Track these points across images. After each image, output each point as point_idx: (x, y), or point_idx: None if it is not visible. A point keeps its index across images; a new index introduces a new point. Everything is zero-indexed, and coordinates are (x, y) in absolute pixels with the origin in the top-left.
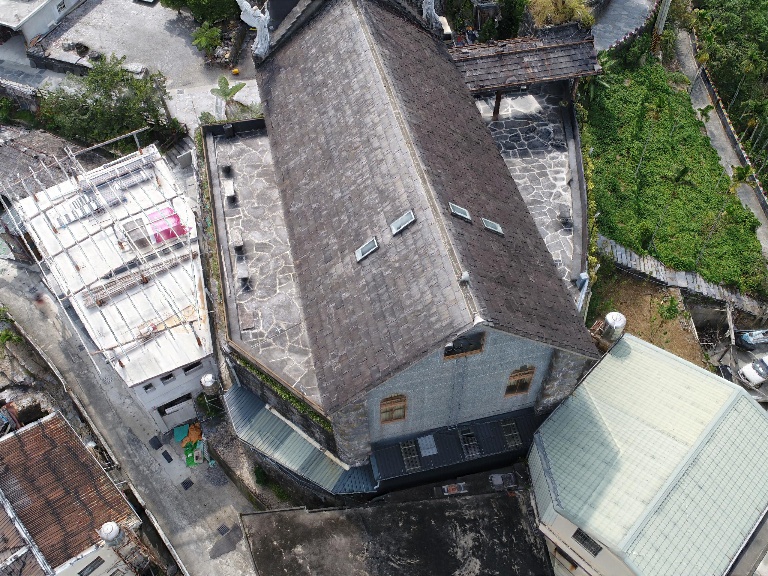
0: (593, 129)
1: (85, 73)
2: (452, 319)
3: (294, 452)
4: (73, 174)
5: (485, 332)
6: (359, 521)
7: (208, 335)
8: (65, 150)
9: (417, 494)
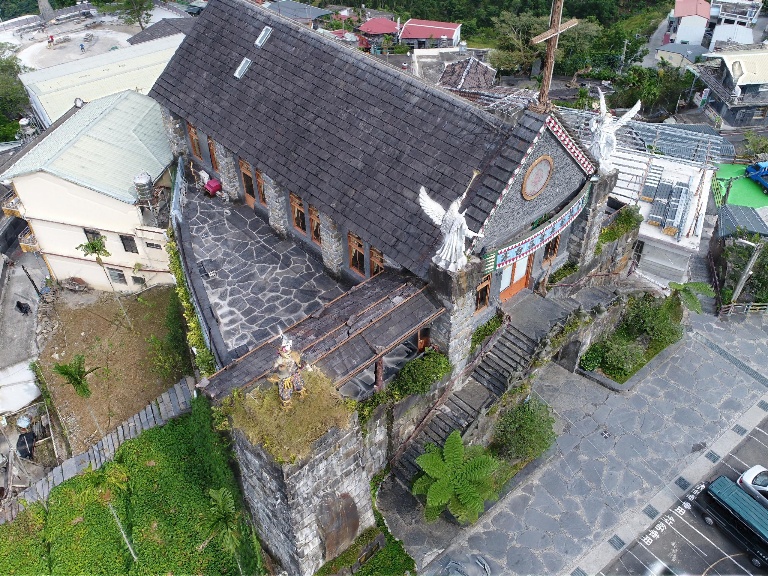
0: None
1: None
2: None
3: None
4: None
5: None
6: None
7: None
8: None
9: None
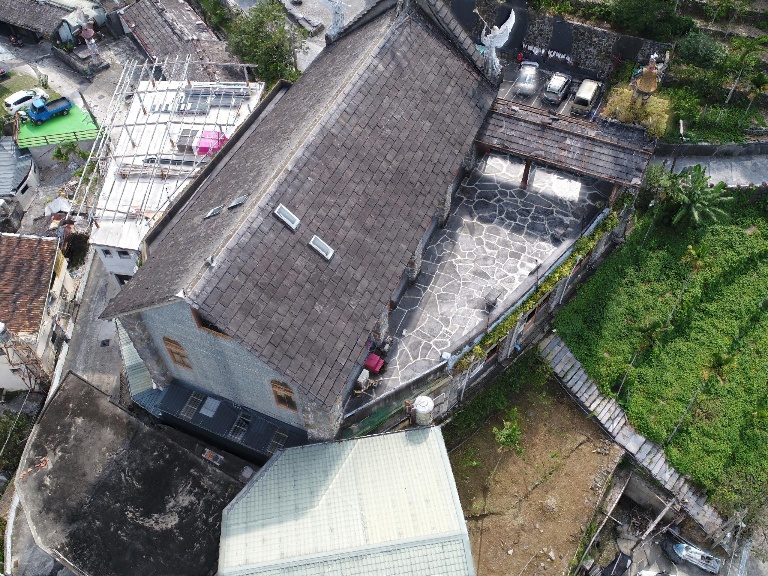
0: (665, 254)
1: (283, 11)
2: None
3: (136, 352)
4: (187, 77)
5: None
6: (133, 430)
7: None
8: (187, 56)
9: (185, 441)
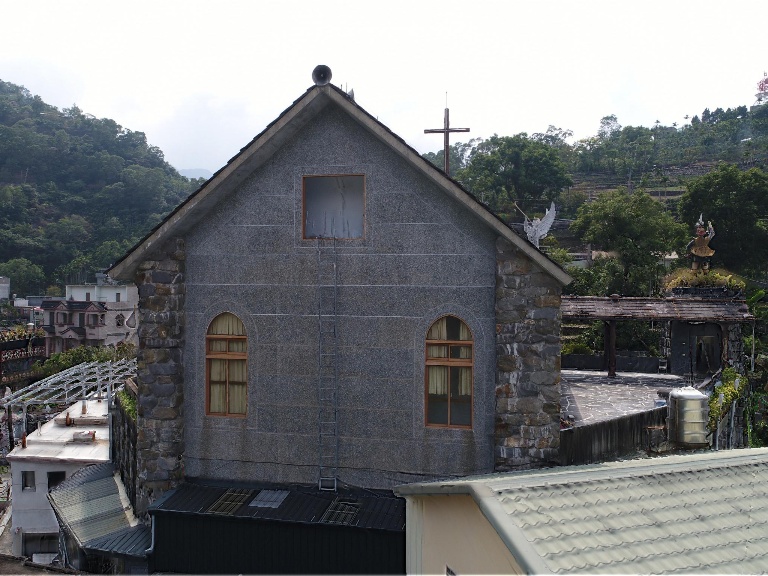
0: None
1: None
2: None
3: (91, 507)
4: None
5: (363, 179)
6: None
7: None
8: None
9: None
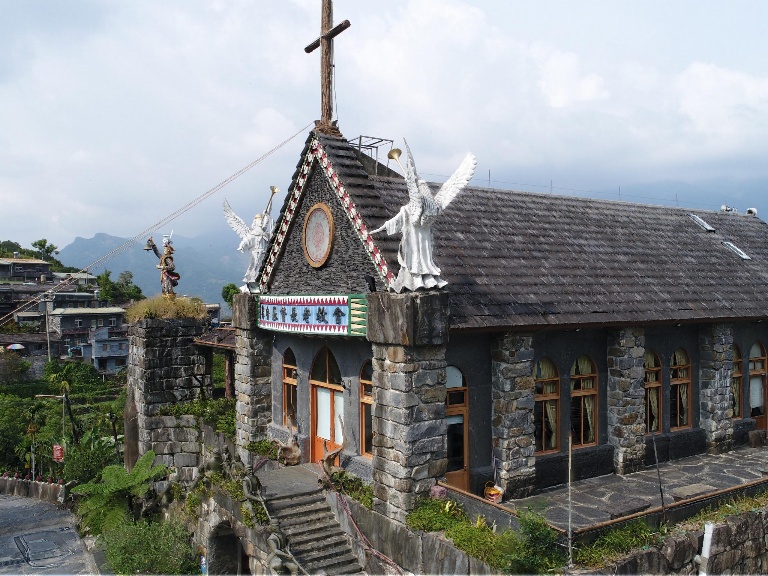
0: None
1: None
2: (759, 221)
3: None
4: None
5: None
6: None
7: None
8: None
9: None
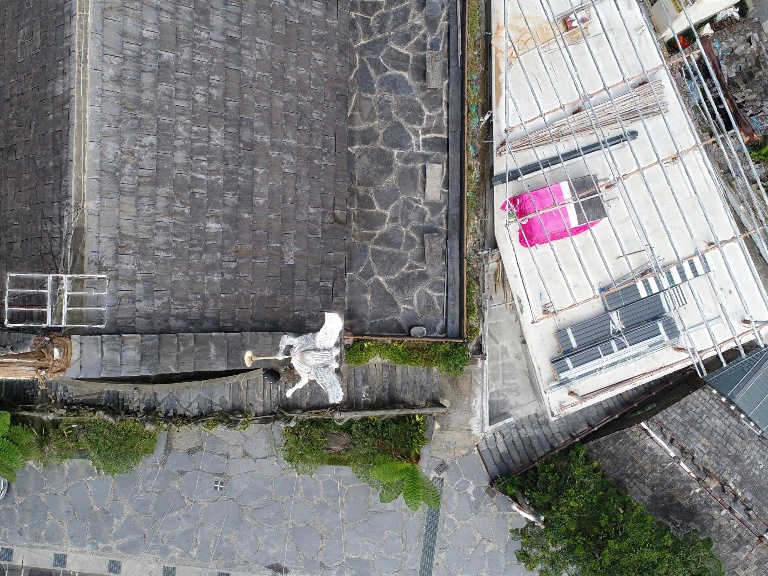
0: None
1: None
2: None
3: None
4: None
5: None
6: None
7: (496, 3)
8: None
9: None
